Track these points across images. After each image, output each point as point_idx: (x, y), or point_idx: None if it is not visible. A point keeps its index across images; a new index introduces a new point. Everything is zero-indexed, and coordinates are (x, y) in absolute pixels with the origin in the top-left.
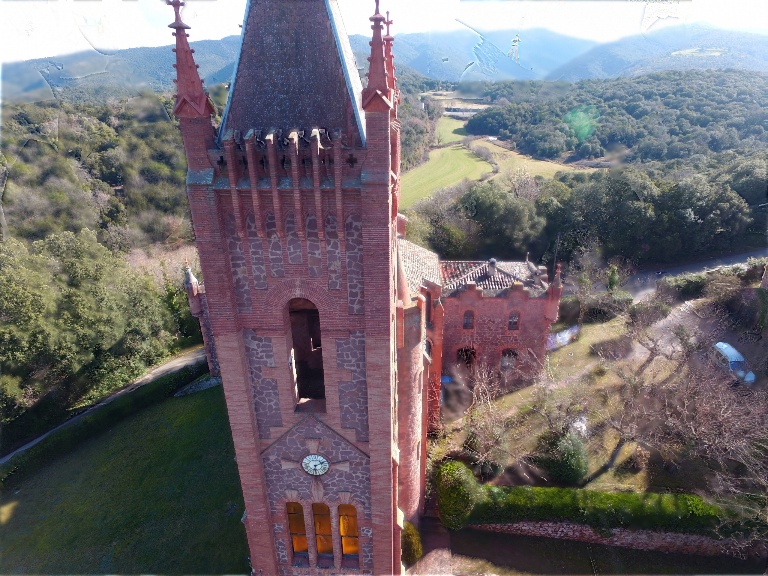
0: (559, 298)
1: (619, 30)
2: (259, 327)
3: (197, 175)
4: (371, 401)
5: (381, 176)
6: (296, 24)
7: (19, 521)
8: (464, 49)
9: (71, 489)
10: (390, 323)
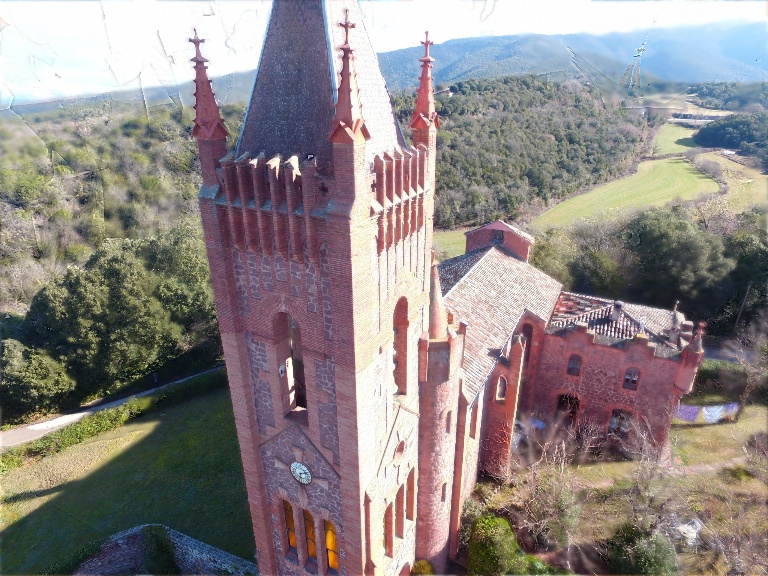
0: (696, 365)
1: None
2: (256, 332)
3: (207, 190)
4: (341, 429)
5: (344, 208)
6: (300, 53)
7: (155, 437)
8: (567, 62)
9: (193, 424)
10: (355, 357)
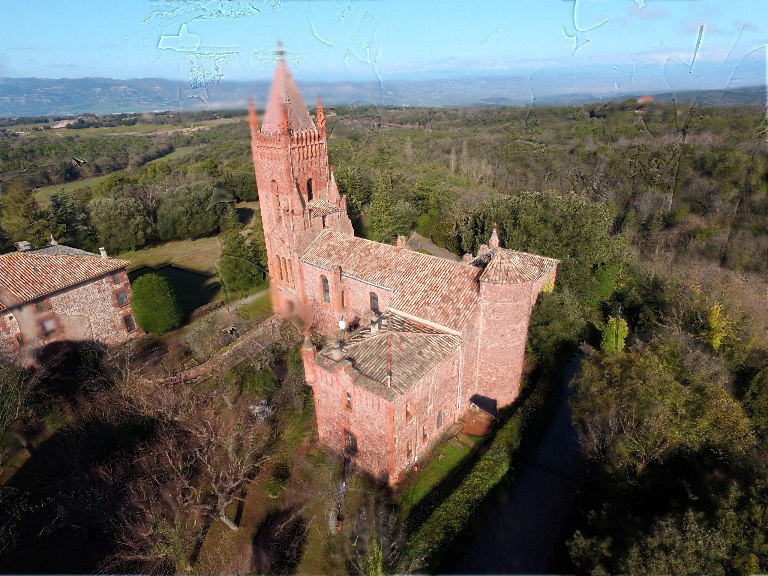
0: None
1: (220, 102)
2: None
3: None
4: None
5: None
6: None
7: None
8: None
9: None
10: None
